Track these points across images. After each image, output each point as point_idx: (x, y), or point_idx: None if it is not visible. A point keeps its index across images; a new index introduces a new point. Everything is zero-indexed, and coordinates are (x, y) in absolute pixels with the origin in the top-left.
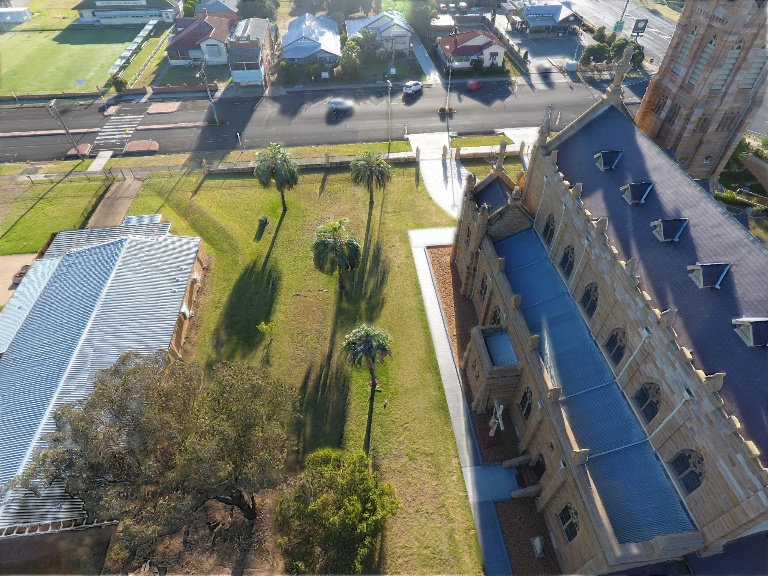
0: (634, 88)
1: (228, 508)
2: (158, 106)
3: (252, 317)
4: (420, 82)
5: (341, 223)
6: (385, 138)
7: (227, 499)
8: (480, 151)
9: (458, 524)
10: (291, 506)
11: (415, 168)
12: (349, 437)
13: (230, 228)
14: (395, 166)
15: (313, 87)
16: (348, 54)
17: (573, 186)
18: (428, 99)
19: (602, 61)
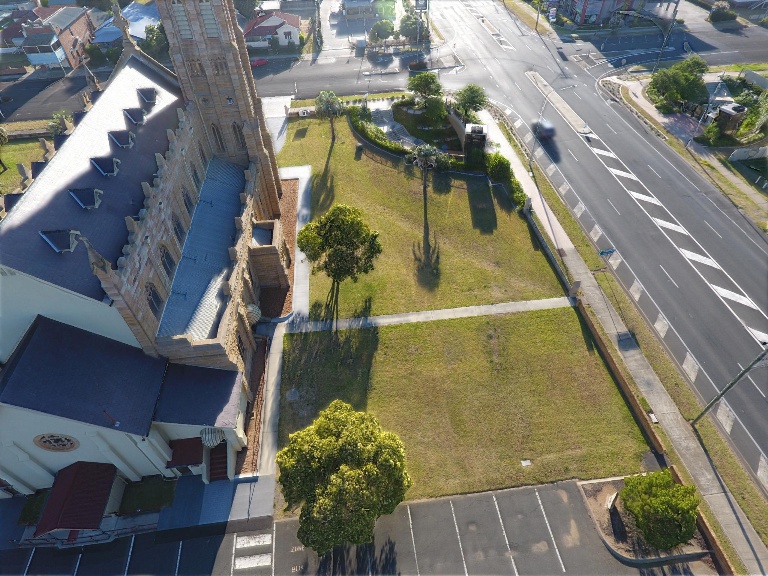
0: (404, 60)
1: None
2: None
3: None
4: None
5: None
6: None
7: None
8: None
9: None
10: None
11: None
12: None
13: None
14: None
15: None
16: (148, 37)
17: None
18: None
19: (387, 37)
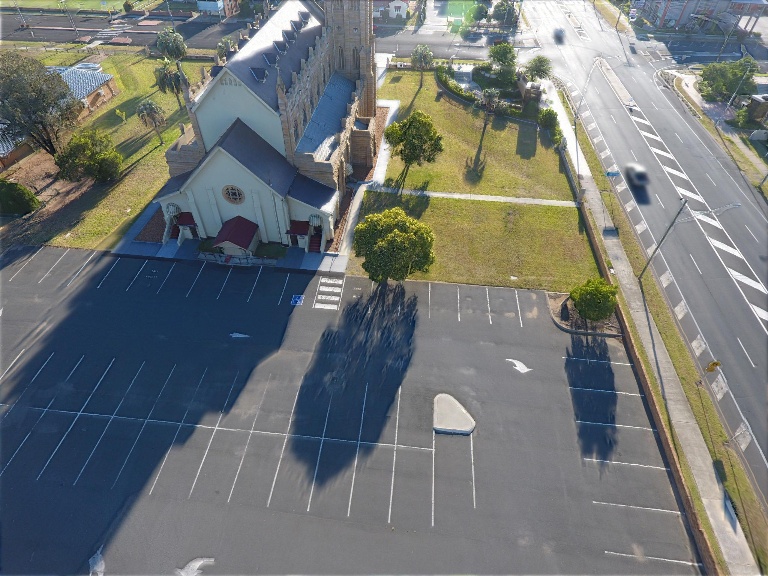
0: (491, 38)
1: (58, 169)
2: (146, 22)
3: None
4: None
5: None
6: None
7: (48, 149)
8: None
9: (156, 186)
10: (68, 149)
11: None
12: (132, 157)
13: (141, 80)
14: None
15: None
16: None
17: None
18: None
19: (480, 19)
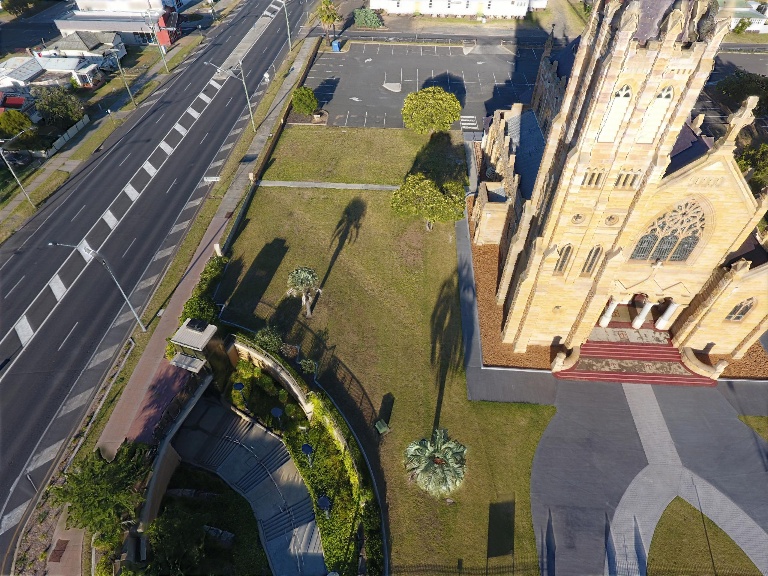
0: None
1: None
2: None
3: None
4: None
5: None
6: None
7: None
8: None
9: None
10: None
11: None
12: None
13: None
14: None
15: None
16: None
17: None
18: None
19: None
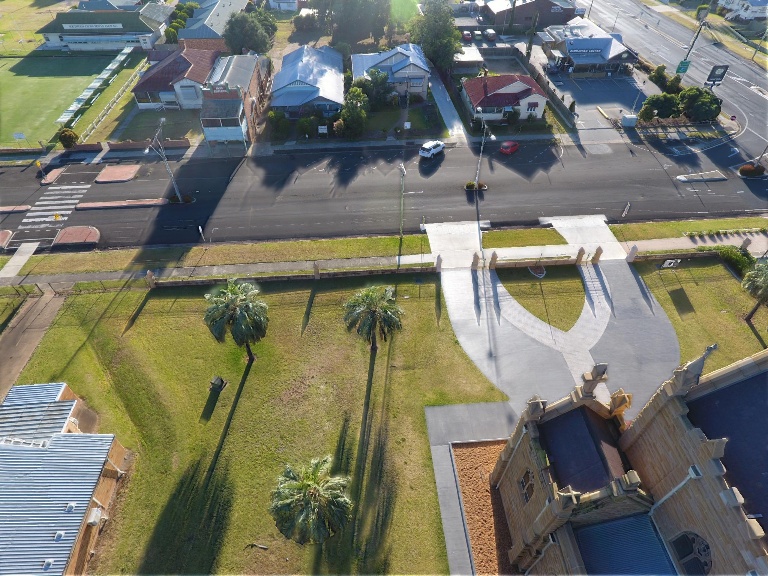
0: (713, 155)
1: None
2: (111, 171)
3: None
4: (441, 142)
5: (319, 468)
6: (395, 229)
7: None
8: (522, 255)
9: None
10: None
11: (435, 284)
12: None
13: (169, 395)
14: (408, 280)
15: (308, 144)
16: (352, 103)
17: (761, 519)
18: (451, 167)
19: (668, 116)
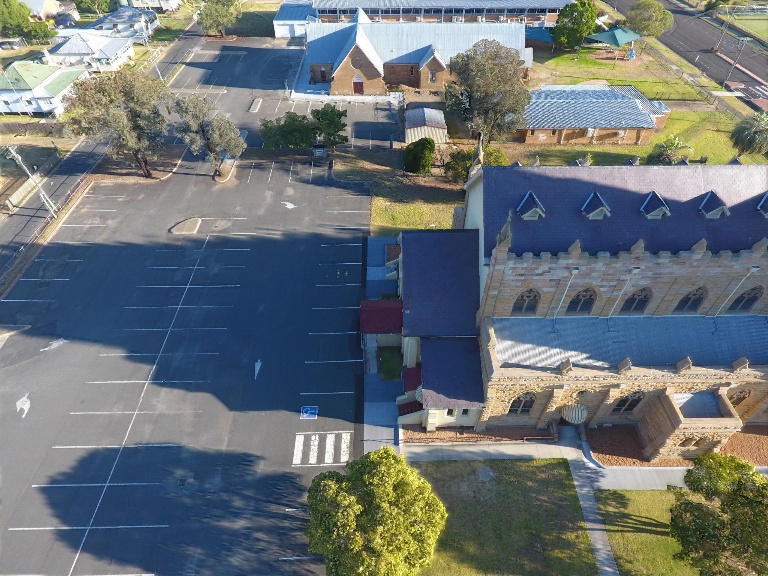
0: None
1: None
2: None
3: (601, 163)
4: None
5: None
6: None
7: None
8: None
9: None
10: None
11: None
12: None
13: None
14: None
15: None
16: None
17: None
18: None
19: None
